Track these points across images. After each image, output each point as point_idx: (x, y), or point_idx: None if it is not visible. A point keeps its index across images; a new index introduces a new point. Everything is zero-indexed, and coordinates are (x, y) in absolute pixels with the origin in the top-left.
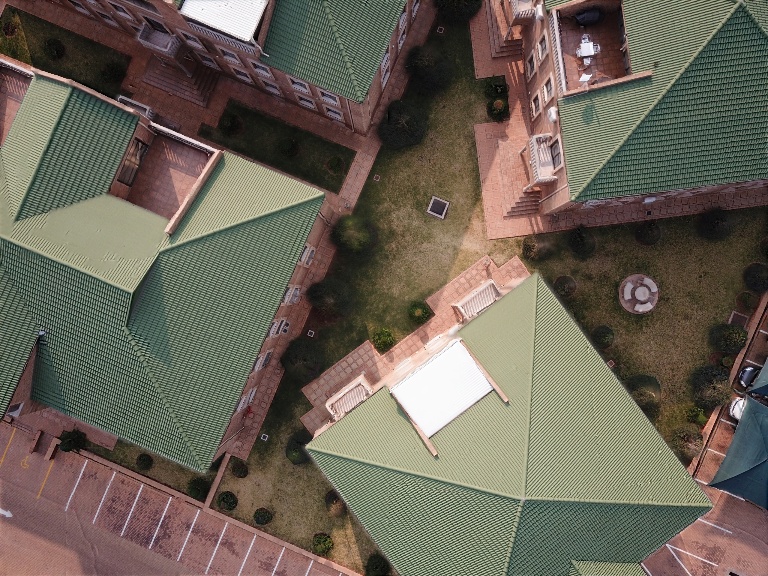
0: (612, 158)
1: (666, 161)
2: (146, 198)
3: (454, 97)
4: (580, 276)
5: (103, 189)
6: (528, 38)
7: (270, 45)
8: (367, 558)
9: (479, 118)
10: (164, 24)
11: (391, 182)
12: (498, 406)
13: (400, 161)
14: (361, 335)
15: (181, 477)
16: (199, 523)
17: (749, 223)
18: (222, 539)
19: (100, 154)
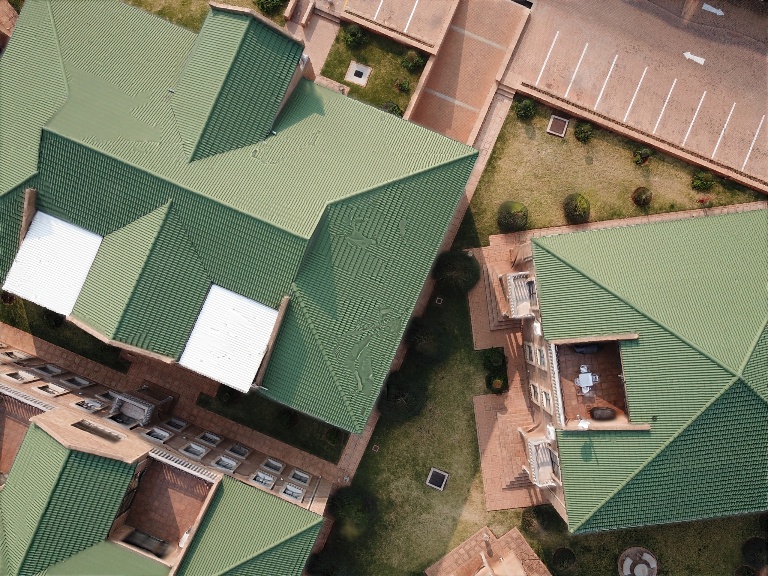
0: (611, 499)
1: (665, 500)
2: (145, 519)
3: (453, 368)
4: (579, 548)
5: (101, 537)
6: (527, 324)
7: (268, 380)
8: None
9: (478, 390)
10: None
11: (390, 453)
12: None
13: (399, 432)
14: None
15: None
16: None
17: None
18: None
19: (98, 505)
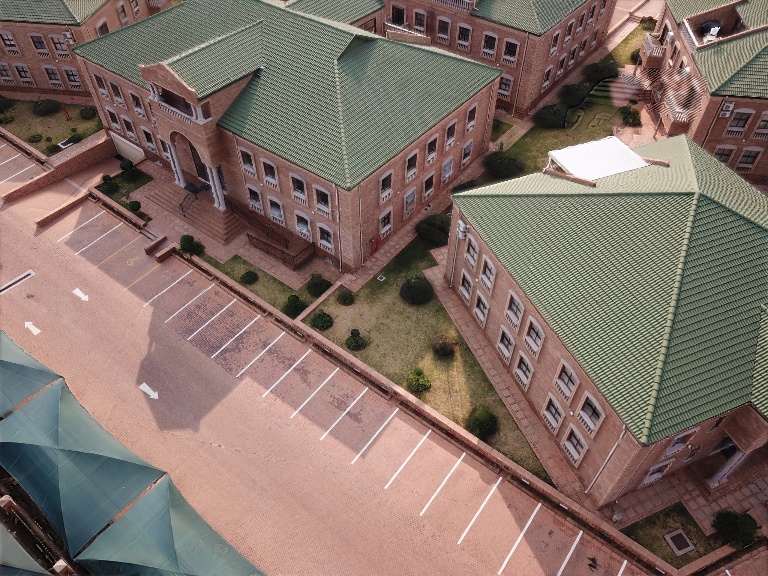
0: (744, 68)
1: None
2: None
3: None
4: None
5: (346, 21)
6: None
7: (481, 5)
8: (469, 411)
9: (616, 123)
10: (406, 8)
11: (540, 143)
12: (658, 168)
13: (549, 135)
14: None
15: (280, 297)
16: (279, 344)
17: None
18: (298, 365)
19: (353, 7)
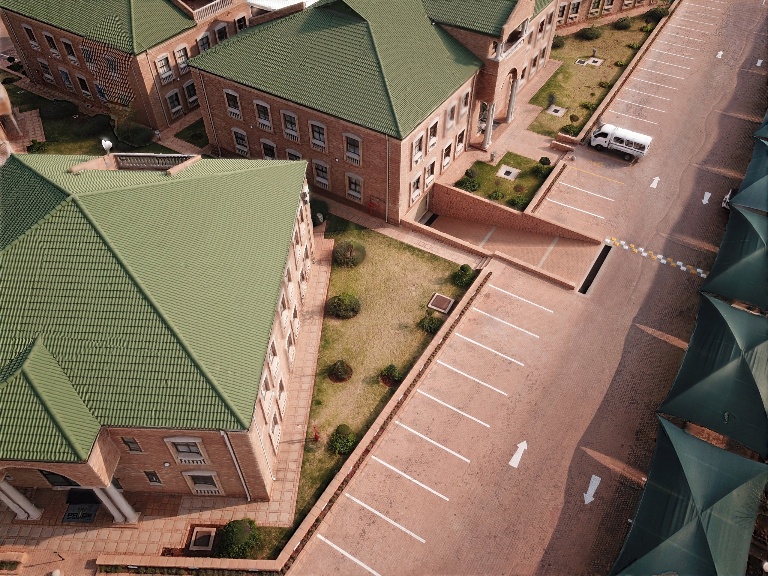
0: None
1: None
2: (189, 2)
3: None
4: None
5: None
6: None
7: None
8: None
9: None
10: None
11: None
12: None
13: None
14: (53, 139)
15: None
16: None
17: None
18: None
19: None
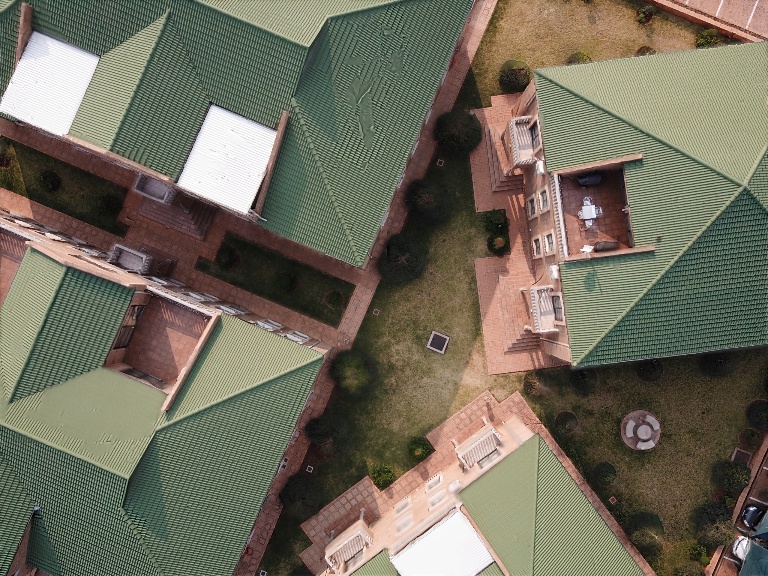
0: (614, 327)
1: (669, 329)
2: (142, 358)
3: (454, 231)
4: (582, 412)
5: (99, 362)
6: (529, 179)
7: (268, 210)
8: None
9: (479, 252)
10: None
11: (391, 316)
12: None
13: (400, 295)
14: (360, 471)
15: None
16: None
17: (752, 359)
18: None
19: (96, 329)
